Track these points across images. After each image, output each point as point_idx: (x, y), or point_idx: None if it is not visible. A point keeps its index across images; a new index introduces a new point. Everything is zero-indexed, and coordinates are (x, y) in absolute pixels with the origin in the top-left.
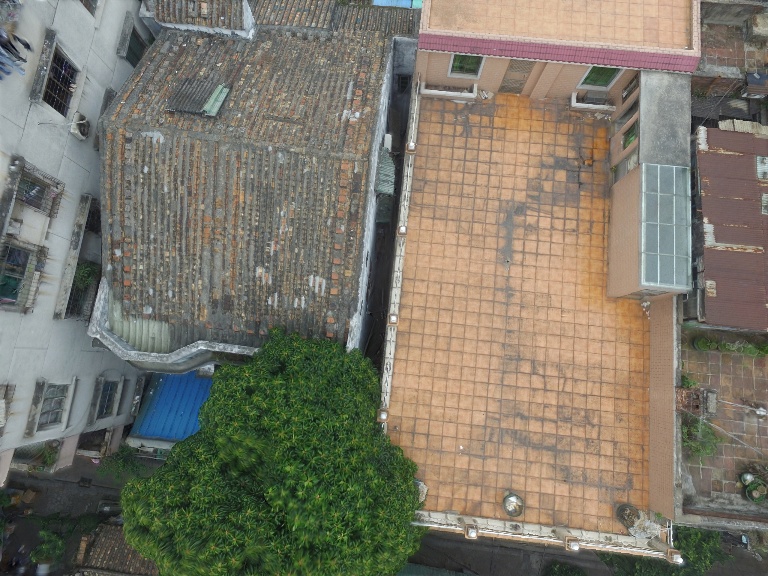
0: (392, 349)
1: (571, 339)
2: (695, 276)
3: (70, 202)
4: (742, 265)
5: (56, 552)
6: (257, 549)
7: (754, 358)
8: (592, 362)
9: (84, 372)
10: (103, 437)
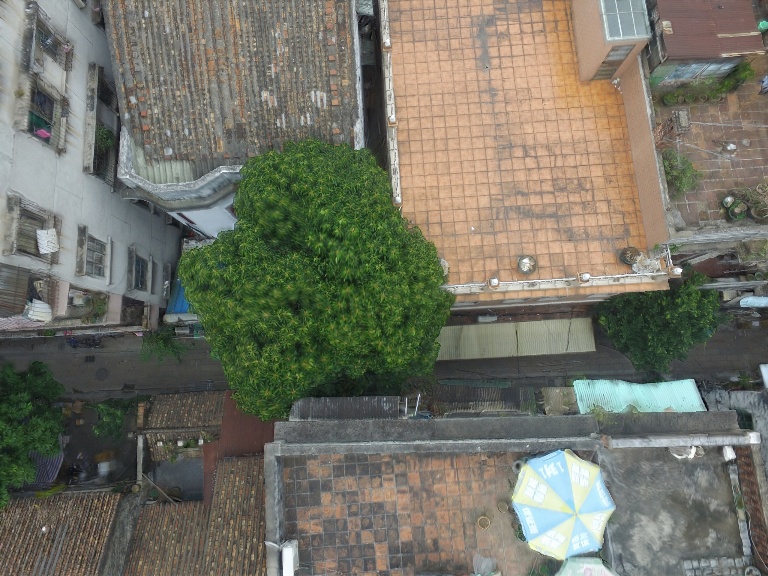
0: (396, 156)
1: (555, 122)
2: (653, 28)
3: (80, 66)
4: (692, 6)
5: (117, 422)
6: (307, 290)
7: (719, 106)
8: (577, 138)
9: (117, 237)
10: (141, 318)
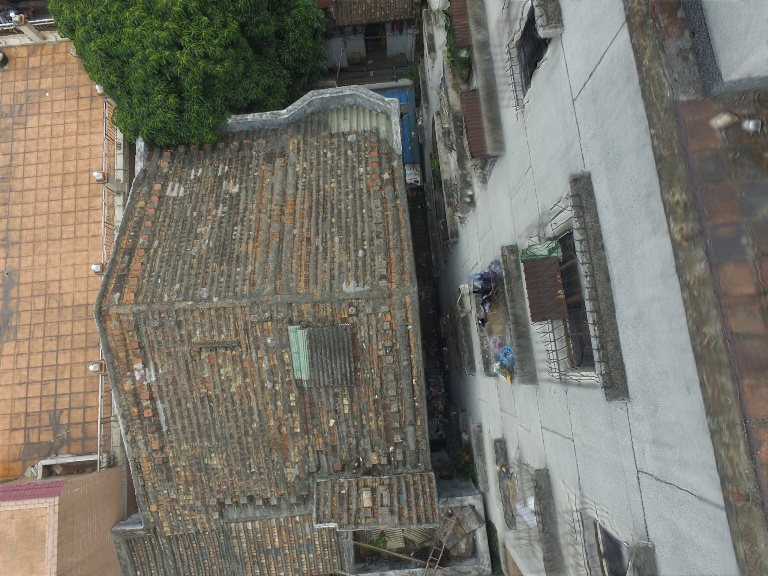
0: None
1: None
2: None
3: None
4: None
5: None
6: None
7: None
8: None
9: None
10: None
